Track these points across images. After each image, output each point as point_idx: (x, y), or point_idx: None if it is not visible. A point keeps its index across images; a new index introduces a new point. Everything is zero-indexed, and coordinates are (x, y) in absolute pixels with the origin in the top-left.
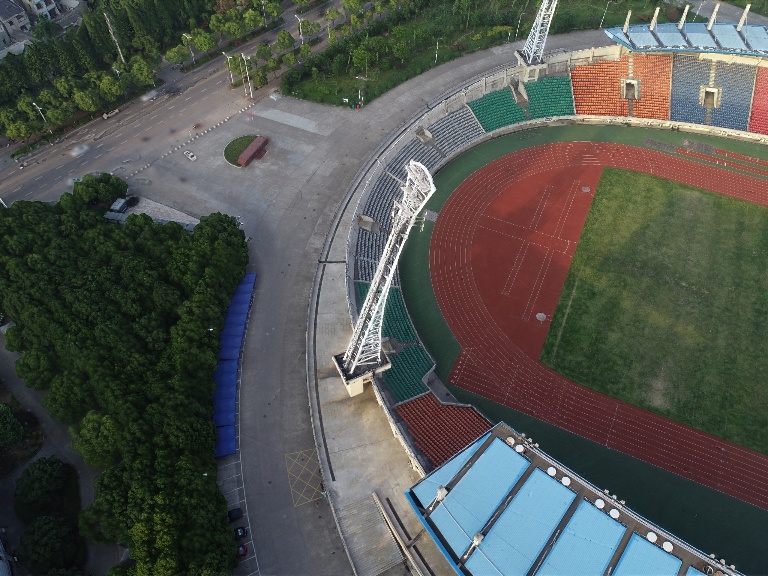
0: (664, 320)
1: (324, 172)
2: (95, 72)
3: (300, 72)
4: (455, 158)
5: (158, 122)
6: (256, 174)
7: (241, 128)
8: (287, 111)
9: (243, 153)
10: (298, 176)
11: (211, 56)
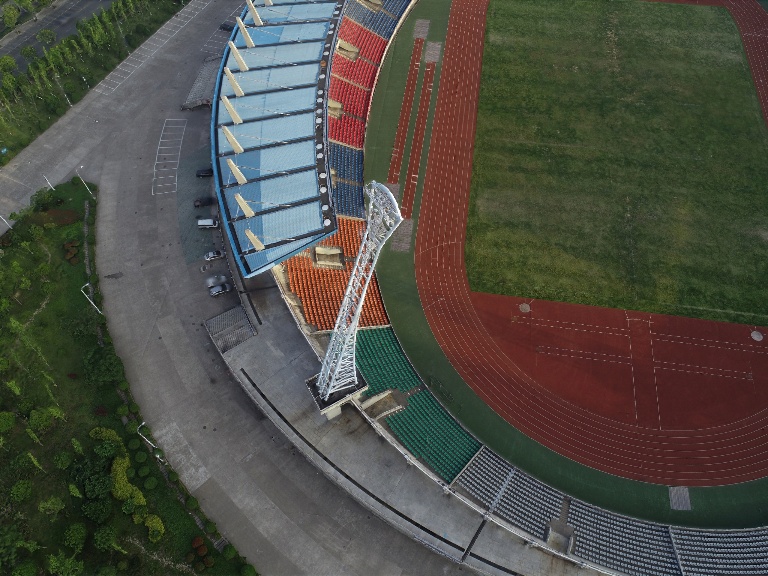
0: (687, 231)
1: None
2: None
3: None
4: None
5: None
6: None
7: None
8: None
9: None
10: None
11: None
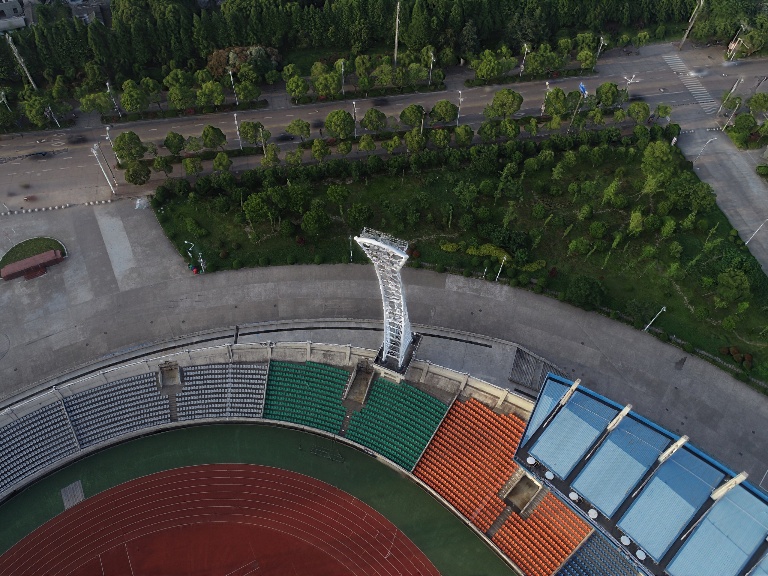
0: None
1: (57, 342)
2: (6, 87)
3: (183, 188)
4: (204, 424)
5: (11, 172)
6: (1, 298)
7: (63, 226)
8: (128, 230)
9: (14, 263)
10: (30, 329)
11: (147, 115)
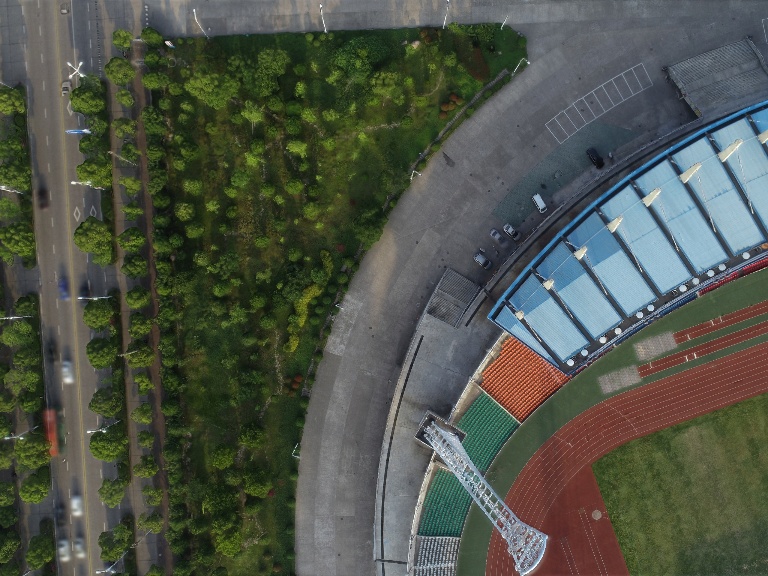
0: None
1: None
2: None
3: None
4: None
5: None
6: None
7: None
8: None
9: None
10: None
11: None
